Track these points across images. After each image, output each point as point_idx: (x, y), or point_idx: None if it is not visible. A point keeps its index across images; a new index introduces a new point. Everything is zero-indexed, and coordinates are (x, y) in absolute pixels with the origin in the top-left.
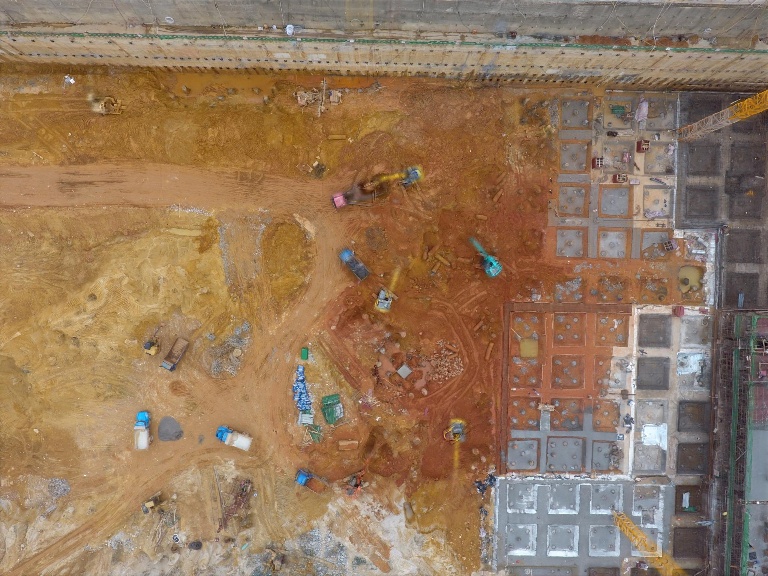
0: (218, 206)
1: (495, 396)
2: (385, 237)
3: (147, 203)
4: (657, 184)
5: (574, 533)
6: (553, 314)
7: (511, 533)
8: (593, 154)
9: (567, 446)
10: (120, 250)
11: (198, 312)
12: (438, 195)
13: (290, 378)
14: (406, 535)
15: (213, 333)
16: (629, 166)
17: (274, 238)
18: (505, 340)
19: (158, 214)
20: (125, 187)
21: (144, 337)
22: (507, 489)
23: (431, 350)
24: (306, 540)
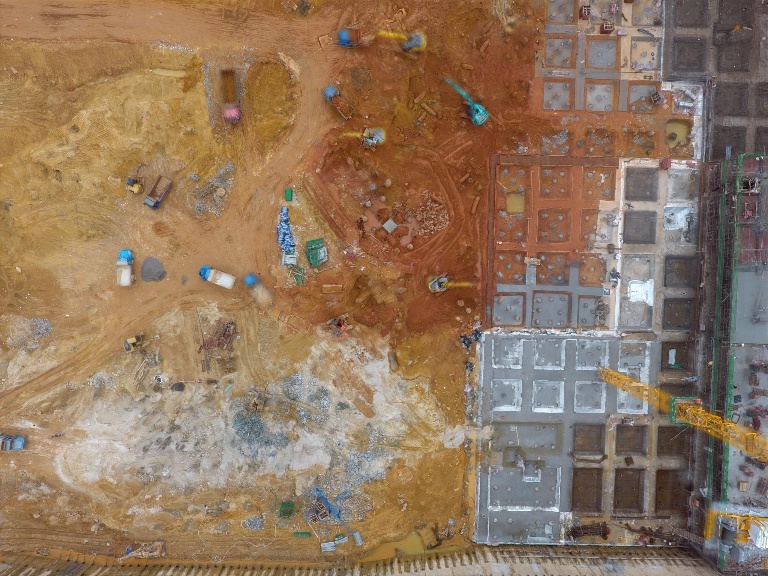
0: (202, 44)
1: (481, 251)
2: (370, 76)
3: (131, 39)
4: (645, 35)
5: (560, 390)
6: (539, 167)
7: (496, 389)
8: (580, 4)
9: (553, 302)
10: (104, 89)
11: (182, 153)
12: (424, 35)
13: (274, 220)
14: (390, 381)
15: (197, 174)
16: (617, 18)
17: (259, 78)
18: (491, 193)
19: (142, 51)
20: (109, 21)
21: (127, 177)
22: (492, 344)
23: (417, 202)
24: (289, 382)
